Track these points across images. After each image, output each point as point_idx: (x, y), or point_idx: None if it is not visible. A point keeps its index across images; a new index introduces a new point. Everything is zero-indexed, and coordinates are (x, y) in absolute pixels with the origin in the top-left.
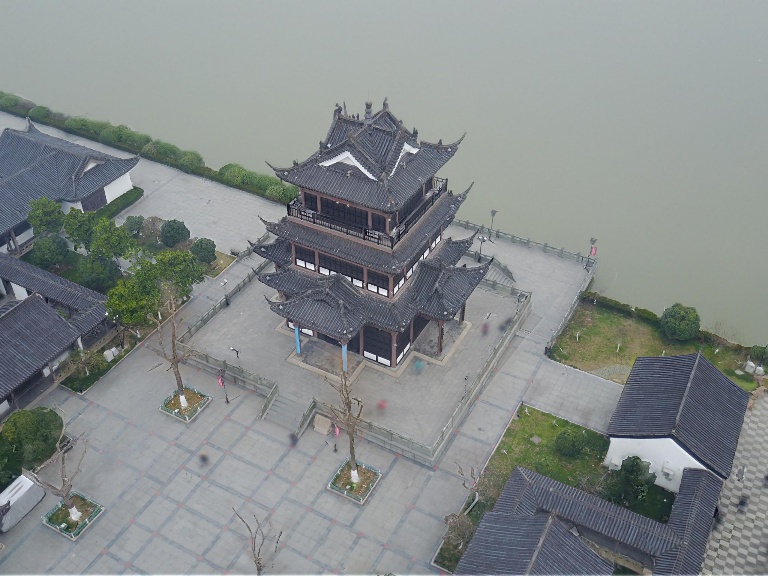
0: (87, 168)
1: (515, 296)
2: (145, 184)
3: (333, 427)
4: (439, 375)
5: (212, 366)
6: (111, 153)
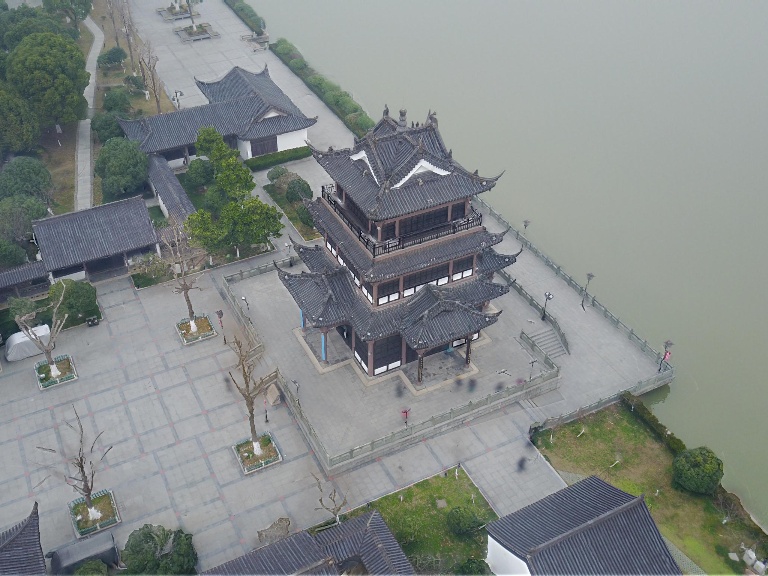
0: (268, 115)
1: (547, 365)
2: (326, 146)
3: (282, 402)
4: (404, 402)
5: (236, 309)
6: (324, 113)
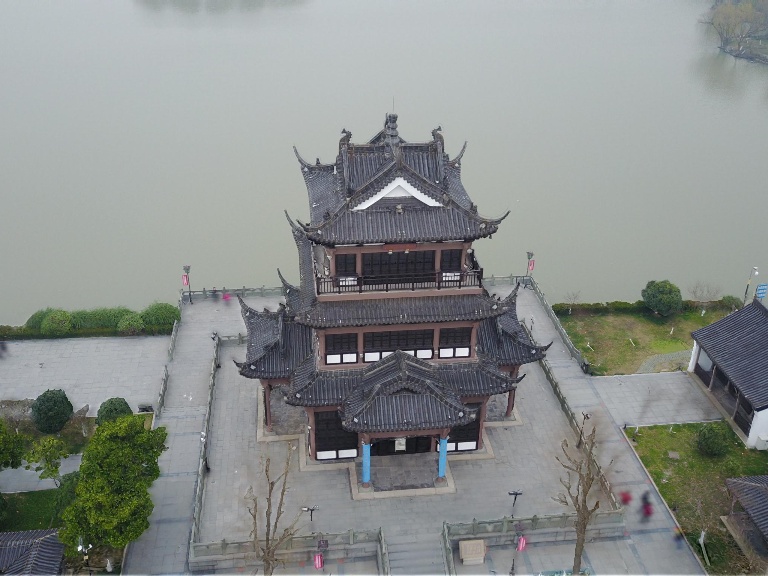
0: None
1: None
2: None
3: None
4: (529, 435)
5: None
6: None
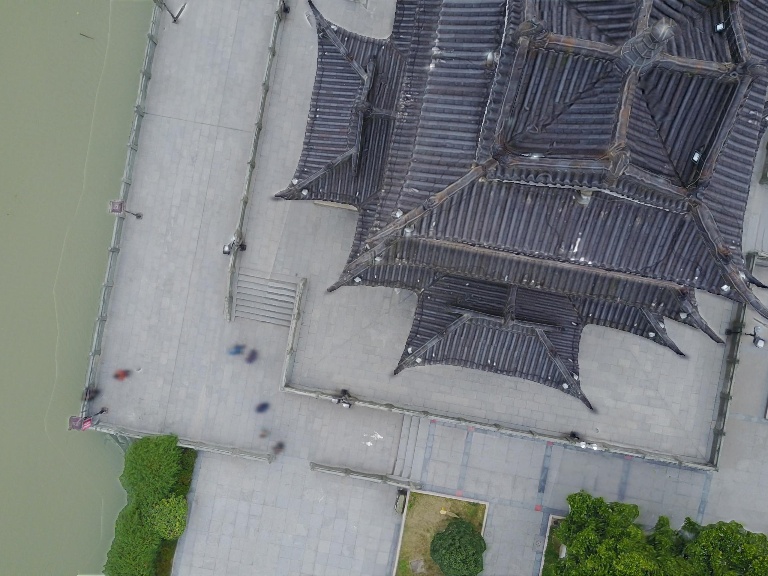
0: None
1: None
2: None
3: None
4: None
5: None
6: None
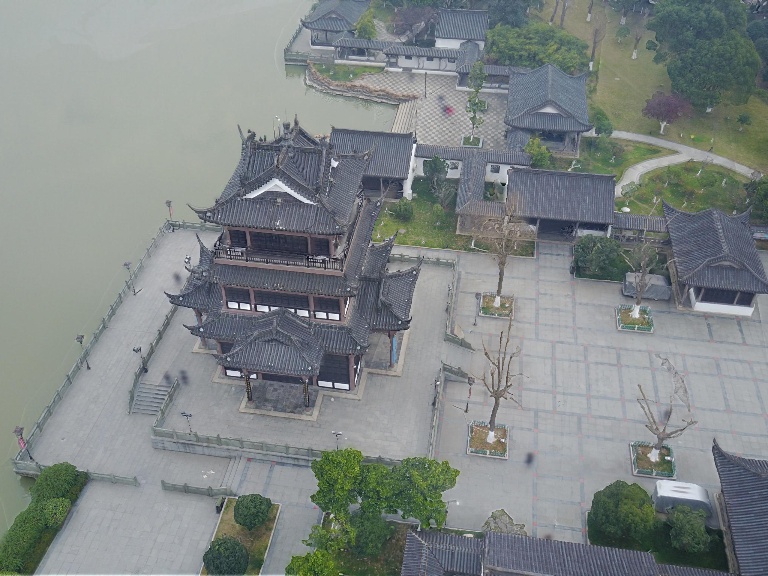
0: None
1: None
2: None
3: None
4: None
5: None
6: None
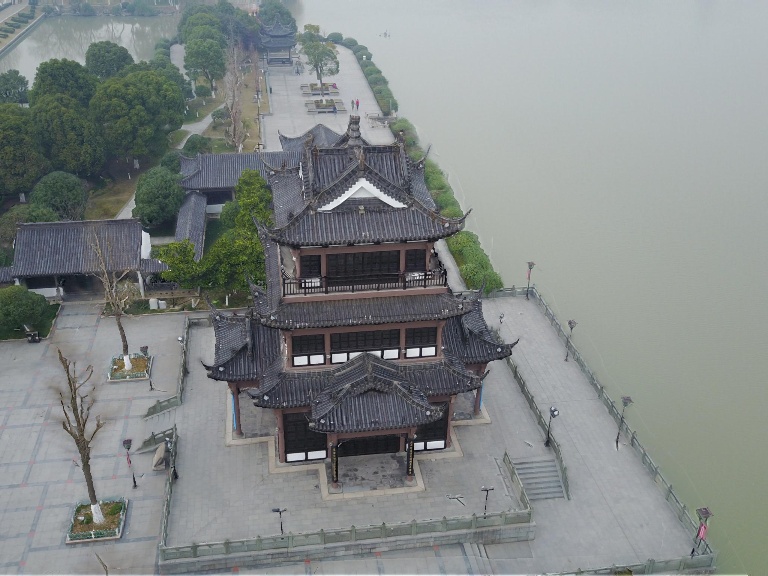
0: None
1: (521, 503)
2: None
3: (167, 468)
4: (305, 503)
5: None
6: None
